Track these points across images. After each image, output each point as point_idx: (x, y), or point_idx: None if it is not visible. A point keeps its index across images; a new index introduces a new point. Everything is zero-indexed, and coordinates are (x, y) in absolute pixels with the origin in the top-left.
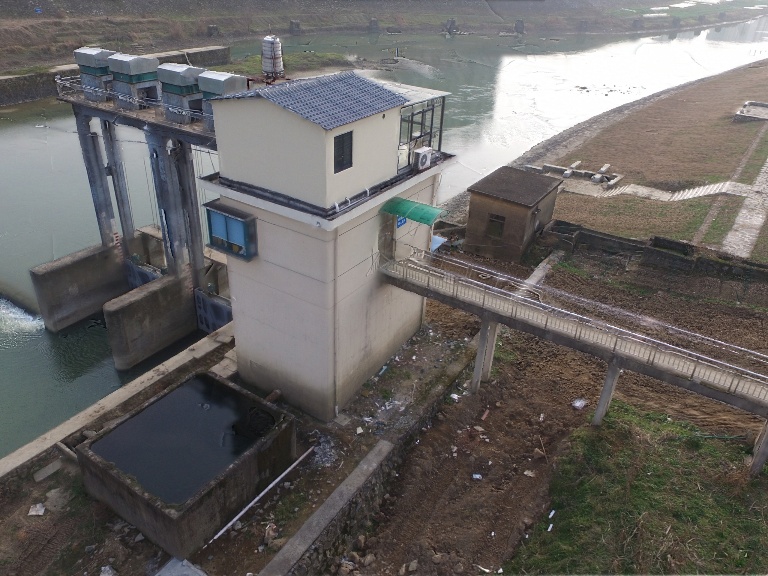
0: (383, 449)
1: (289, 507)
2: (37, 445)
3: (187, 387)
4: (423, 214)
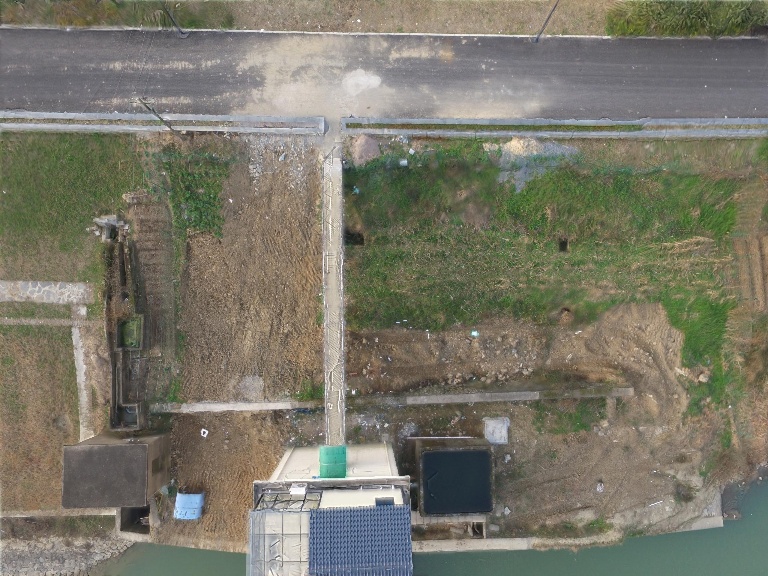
0: (412, 400)
1: (441, 423)
2: (492, 545)
3: (436, 511)
4: (340, 454)
